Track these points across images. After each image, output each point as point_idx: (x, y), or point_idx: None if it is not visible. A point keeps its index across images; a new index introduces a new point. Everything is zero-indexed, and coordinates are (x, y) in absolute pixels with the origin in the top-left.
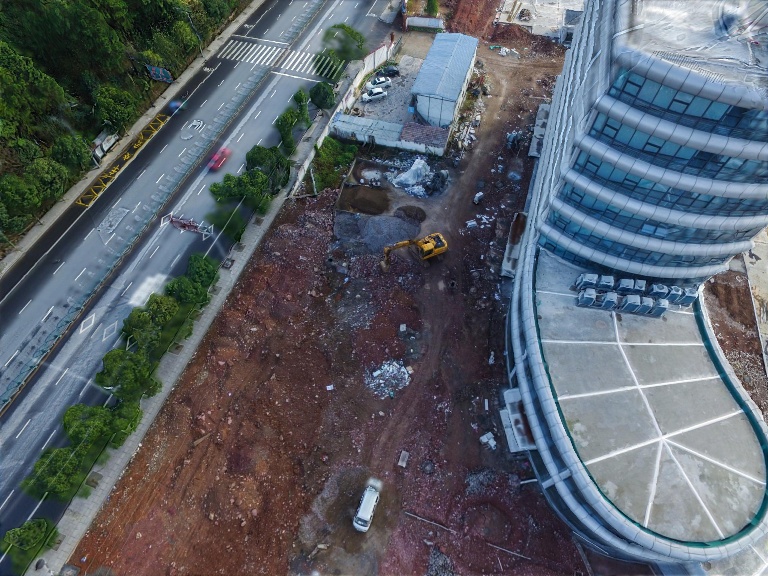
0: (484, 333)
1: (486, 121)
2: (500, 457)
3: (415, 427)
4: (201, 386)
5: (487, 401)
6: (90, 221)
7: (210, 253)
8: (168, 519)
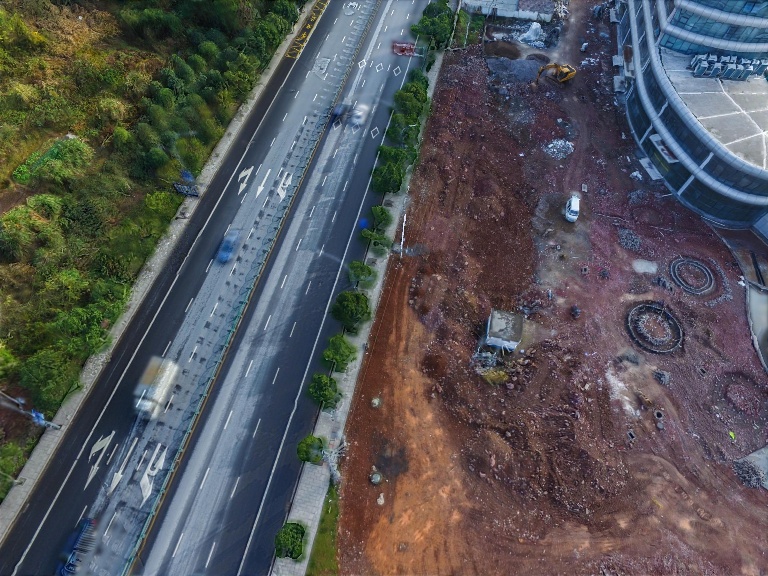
0: (614, 123)
1: (572, 1)
2: (645, 184)
3: (586, 172)
4: (436, 155)
5: (628, 157)
6: (304, 67)
7: (405, 83)
8: (447, 220)
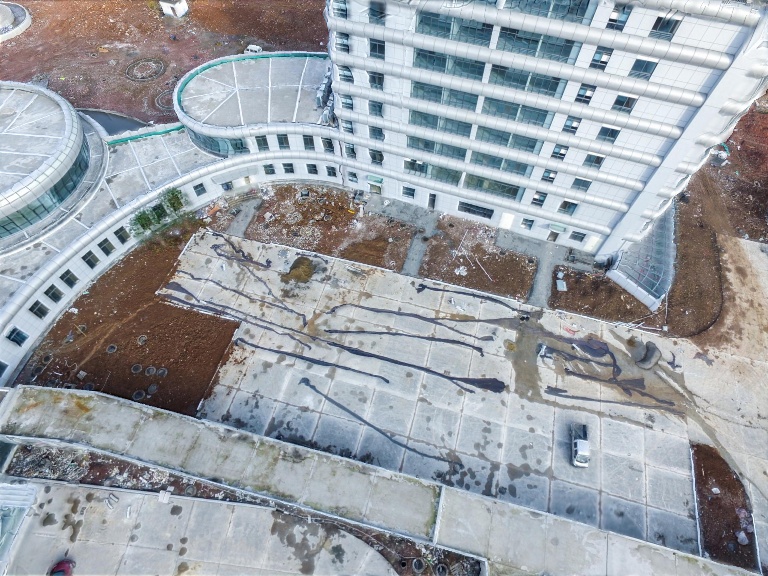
0: None
1: None
2: None
3: None
4: None
5: None
6: None
7: None
8: (265, 1)
